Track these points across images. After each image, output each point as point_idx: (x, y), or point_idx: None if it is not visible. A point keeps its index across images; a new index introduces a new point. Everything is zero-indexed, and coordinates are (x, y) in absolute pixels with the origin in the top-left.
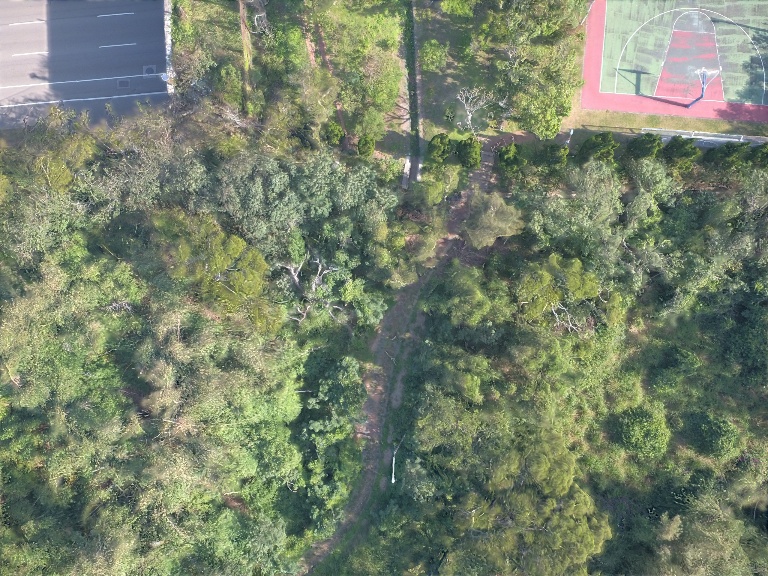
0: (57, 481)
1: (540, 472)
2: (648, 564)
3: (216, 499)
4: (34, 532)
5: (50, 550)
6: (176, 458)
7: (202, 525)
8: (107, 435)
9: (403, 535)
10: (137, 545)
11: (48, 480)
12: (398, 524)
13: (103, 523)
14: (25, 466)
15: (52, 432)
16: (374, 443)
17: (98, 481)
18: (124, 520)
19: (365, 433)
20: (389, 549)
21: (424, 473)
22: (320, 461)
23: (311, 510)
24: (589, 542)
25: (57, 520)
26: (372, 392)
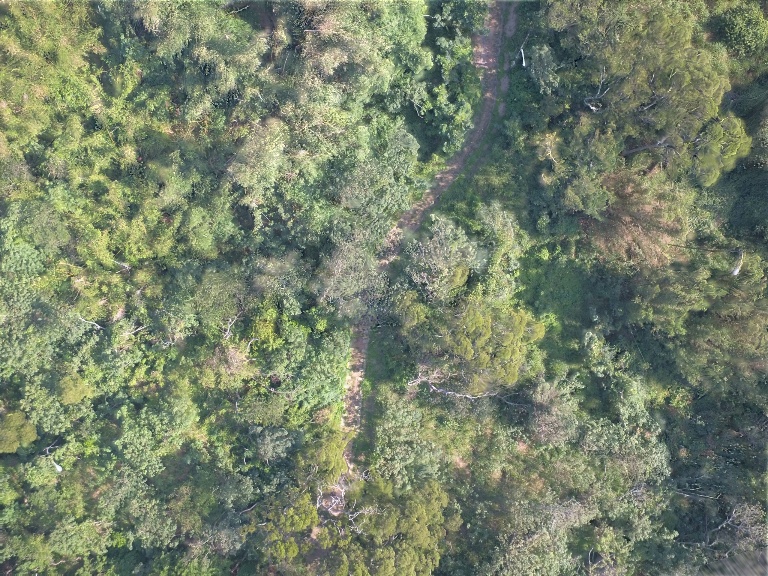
0: (193, 133)
1: (663, 31)
2: (766, 106)
3: (351, 119)
4: (180, 162)
5: (195, 183)
6: (314, 76)
7: (344, 132)
8: (252, 49)
9: (525, 150)
10: (283, 156)
11: (182, 139)
12: (521, 136)
13: (246, 148)
14: (159, 127)
15: (189, 79)
16: (491, 72)
17: (237, 116)
18: (266, 144)
19: (482, 63)
20: (513, 162)
21: (551, 58)
22: (443, 87)
23: (440, 126)
24: (715, 79)
25: (199, 156)
26: (487, 25)
